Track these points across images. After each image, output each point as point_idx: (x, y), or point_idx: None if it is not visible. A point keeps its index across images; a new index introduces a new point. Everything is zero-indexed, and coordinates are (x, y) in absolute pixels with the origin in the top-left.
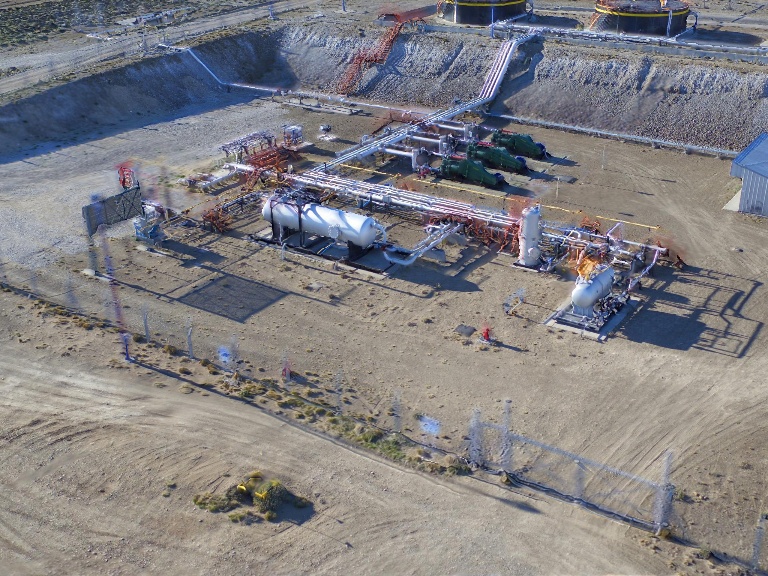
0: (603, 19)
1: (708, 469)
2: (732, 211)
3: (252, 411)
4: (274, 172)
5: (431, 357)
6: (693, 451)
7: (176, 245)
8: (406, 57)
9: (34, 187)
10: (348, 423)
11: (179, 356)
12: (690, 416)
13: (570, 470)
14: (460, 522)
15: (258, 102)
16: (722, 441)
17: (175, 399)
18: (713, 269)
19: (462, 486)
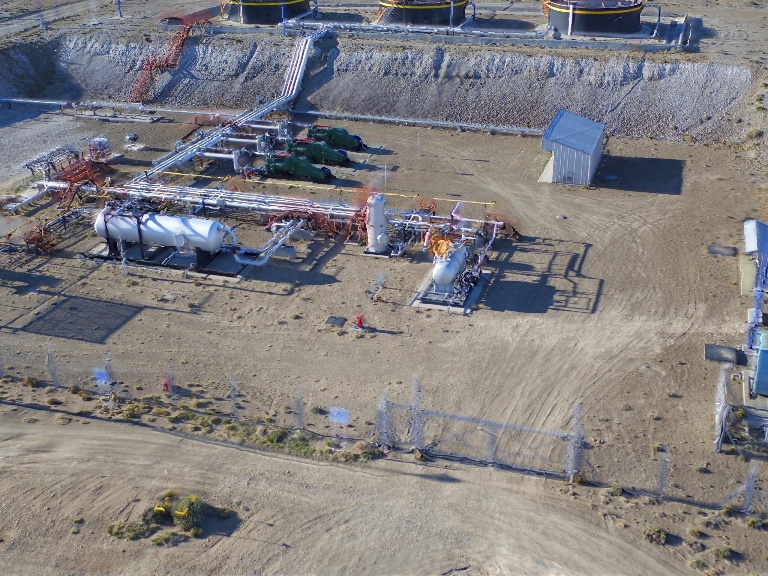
0: (389, 13)
1: (596, 416)
2: (547, 183)
3: (143, 431)
4: (91, 186)
5: (311, 351)
6: (579, 402)
7: (1, 273)
8: (199, 60)
9: None
10: (248, 428)
11: (43, 387)
12: (567, 371)
13: (476, 437)
14: (389, 504)
15: (46, 117)
16: (601, 389)
17: (53, 432)
18: (546, 237)
19: (380, 469)
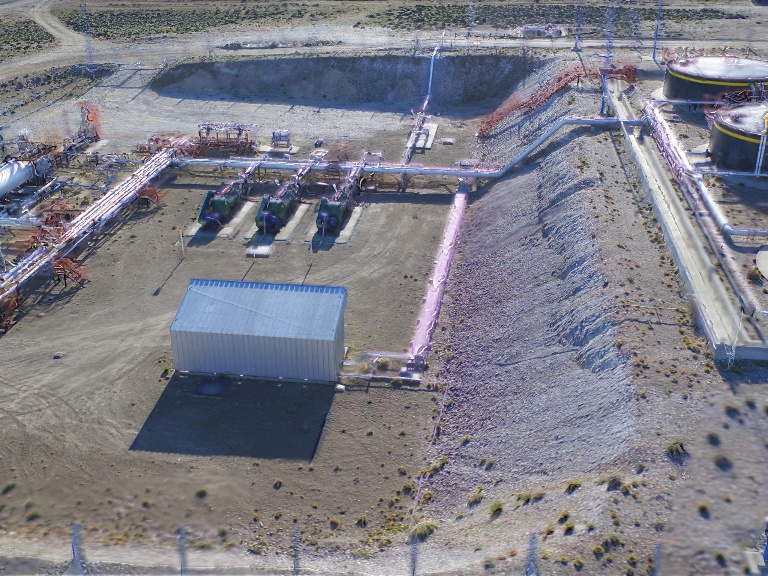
0: None
1: None
2: None
3: None
4: None
5: None
6: None
7: None
8: (543, 112)
9: (127, 113)
10: None
11: None
12: None
13: None
14: None
15: (416, 117)
16: None
17: None
18: None
19: None
